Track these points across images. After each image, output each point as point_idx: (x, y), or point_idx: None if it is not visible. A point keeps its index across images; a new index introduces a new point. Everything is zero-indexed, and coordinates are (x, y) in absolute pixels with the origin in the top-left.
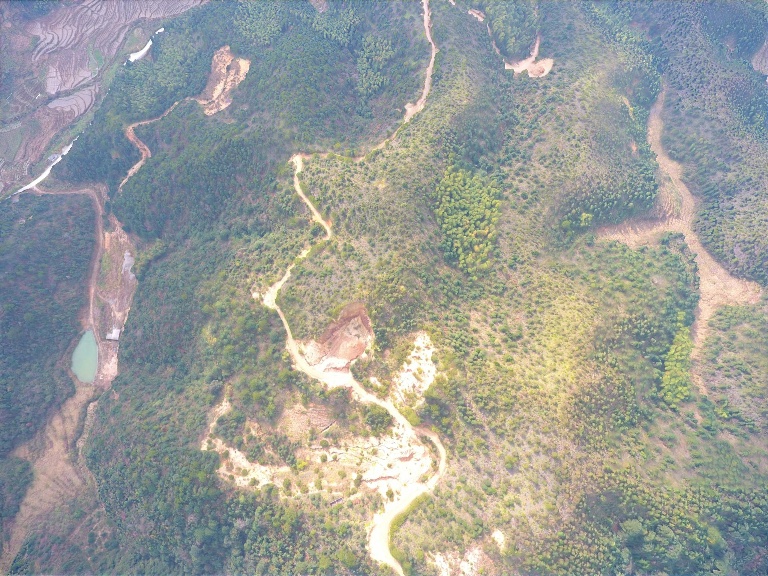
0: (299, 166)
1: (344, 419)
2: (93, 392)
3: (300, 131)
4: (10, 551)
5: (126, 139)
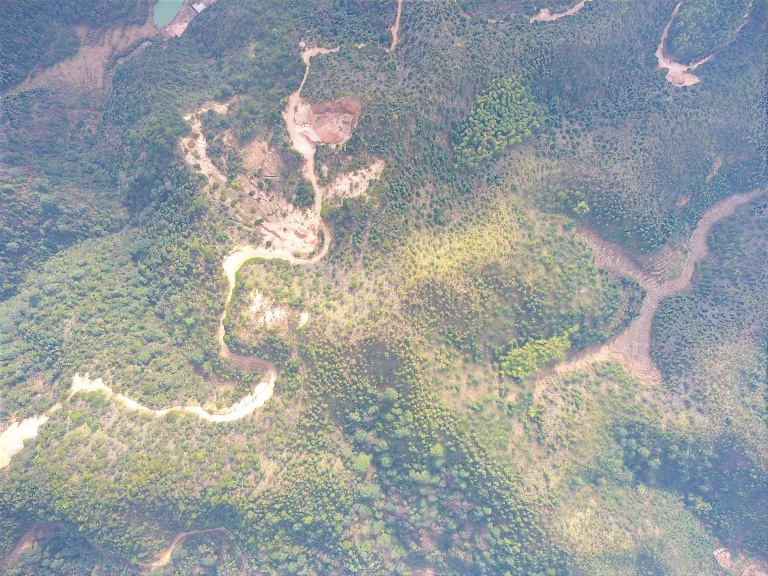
0: None
1: (285, 179)
2: (155, 35)
3: None
4: (28, 85)
5: None
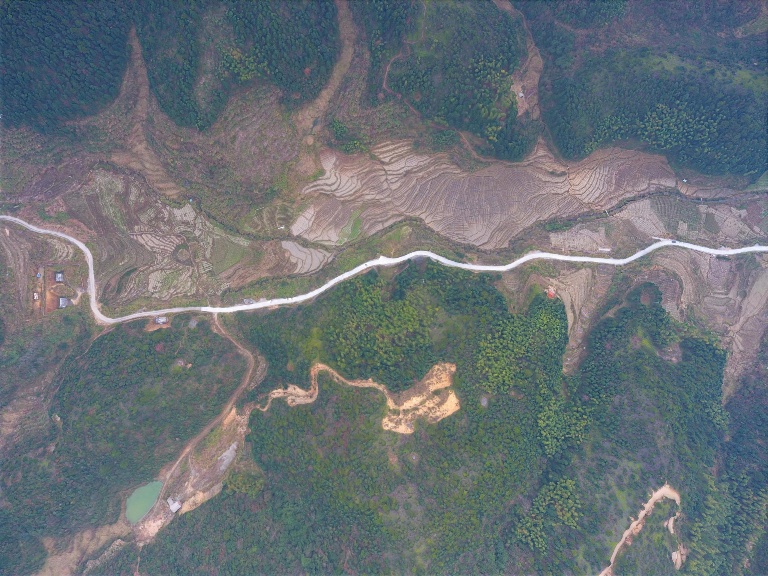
0: None
1: None
2: (127, 533)
3: (429, 570)
4: None
5: (308, 372)
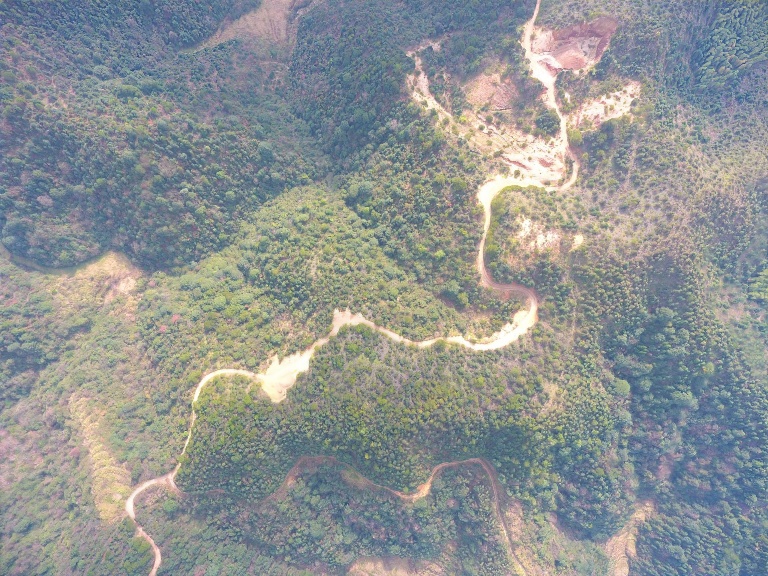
0: None
1: (520, 110)
2: None
3: None
4: (219, 38)
5: None
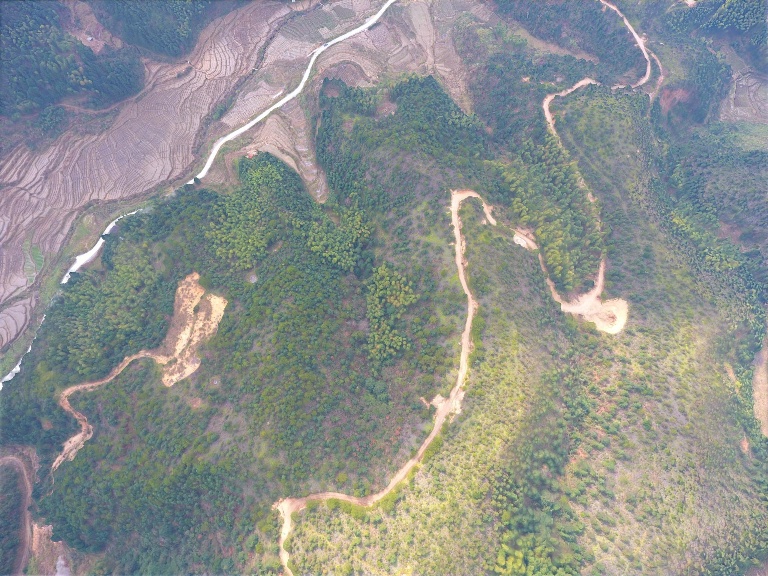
0: (287, 519)
1: None
2: None
3: (289, 461)
4: None
5: (59, 411)
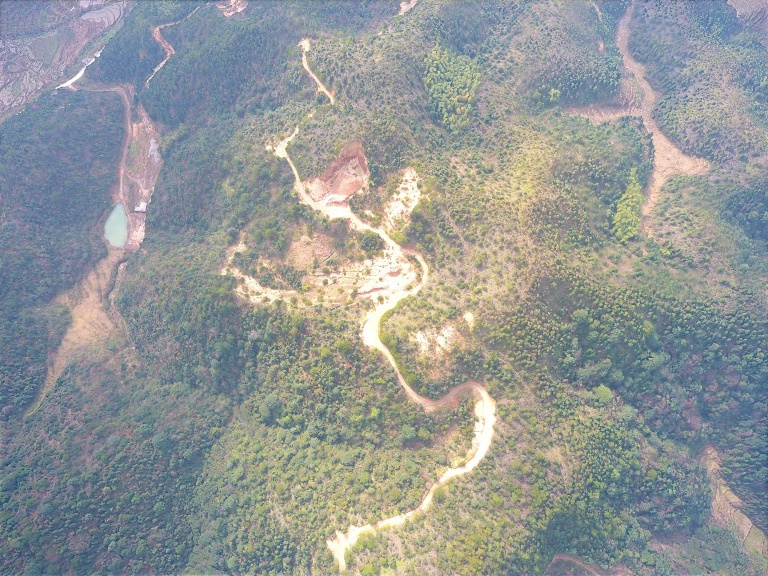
0: (307, 48)
1: (343, 247)
2: (123, 254)
3: (308, 19)
4: (54, 374)
5: (153, 39)
